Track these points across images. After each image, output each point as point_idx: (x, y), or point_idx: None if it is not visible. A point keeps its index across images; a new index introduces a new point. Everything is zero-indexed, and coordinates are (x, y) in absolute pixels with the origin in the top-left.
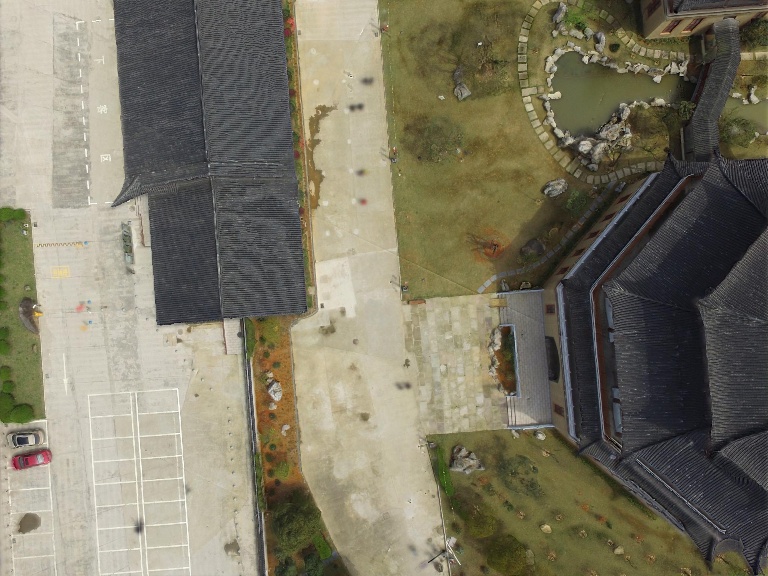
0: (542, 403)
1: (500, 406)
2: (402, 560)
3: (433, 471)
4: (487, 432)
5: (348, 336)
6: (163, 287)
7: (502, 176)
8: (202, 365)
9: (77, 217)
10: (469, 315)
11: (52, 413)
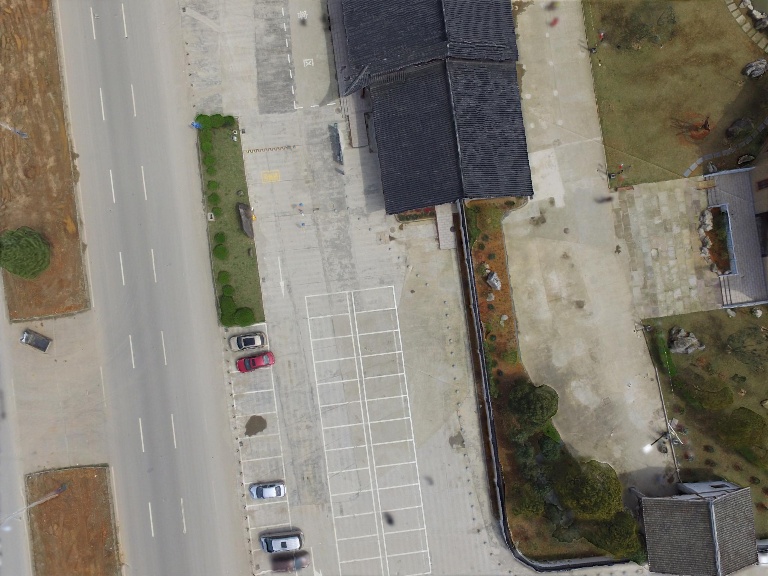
0: (756, 281)
1: (713, 287)
2: (625, 444)
3: (650, 355)
4: (702, 313)
5: (559, 226)
6: (392, 176)
7: (702, 60)
8: (416, 261)
9: (284, 122)
10: (677, 199)
11: (271, 316)
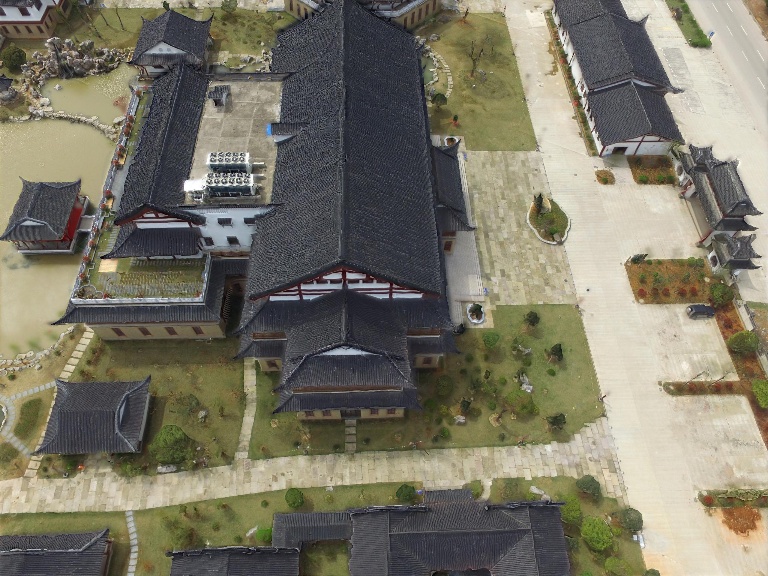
0: None
1: None
2: None
3: None
4: None
5: (528, 5)
6: (618, 1)
7: (459, 45)
8: None
9: (667, 45)
10: (473, 7)
11: None
